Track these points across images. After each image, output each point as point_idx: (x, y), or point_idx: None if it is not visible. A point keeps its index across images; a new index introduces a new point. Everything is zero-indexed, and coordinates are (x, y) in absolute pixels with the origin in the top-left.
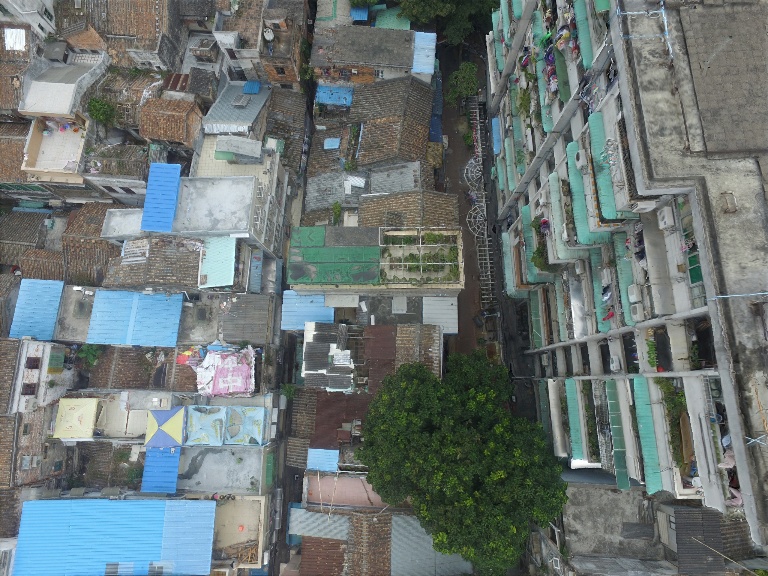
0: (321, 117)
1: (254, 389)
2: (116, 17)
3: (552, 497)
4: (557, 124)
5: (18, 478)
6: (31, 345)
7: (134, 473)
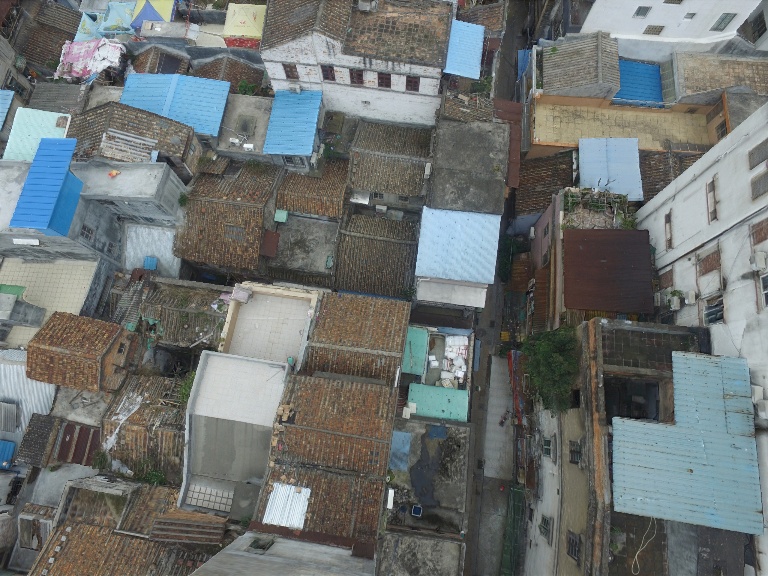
0: None
1: None
2: (132, 574)
3: None
4: None
5: None
6: None
7: None
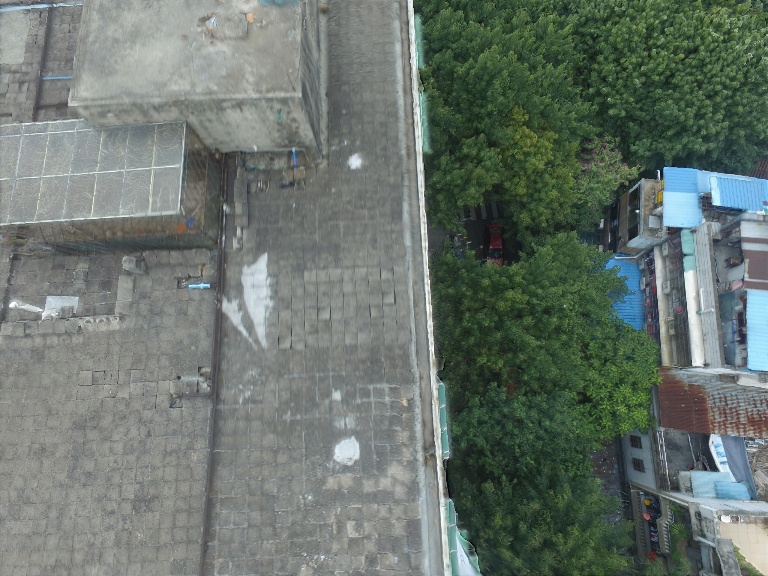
0: None
1: None
2: None
3: None
4: None
5: None
6: None
7: None
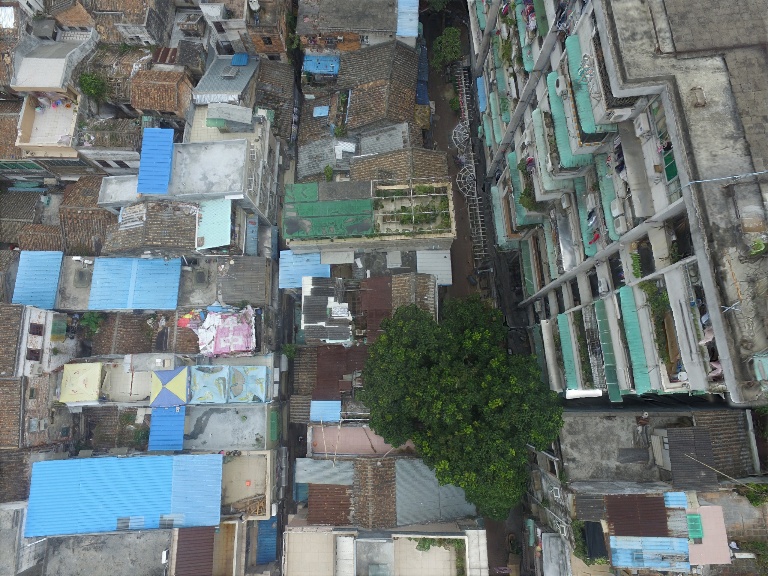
0: (309, 85)
1: (255, 349)
2: None
3: (548, 421)
4: (537, 61)
5: (27, 440)
6: (33, 311)
7: (141, 434)
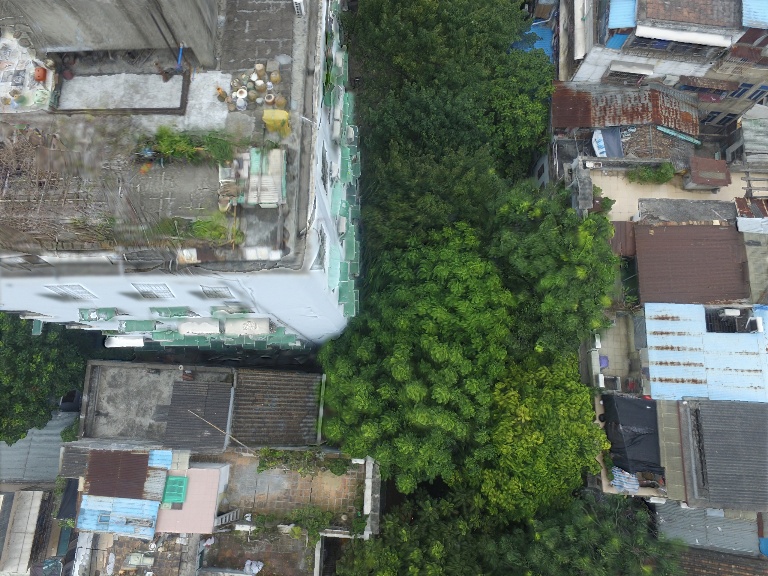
0: None
1: None
2: None
3: (29, 362)
4: None
5: None
6: None
7: None
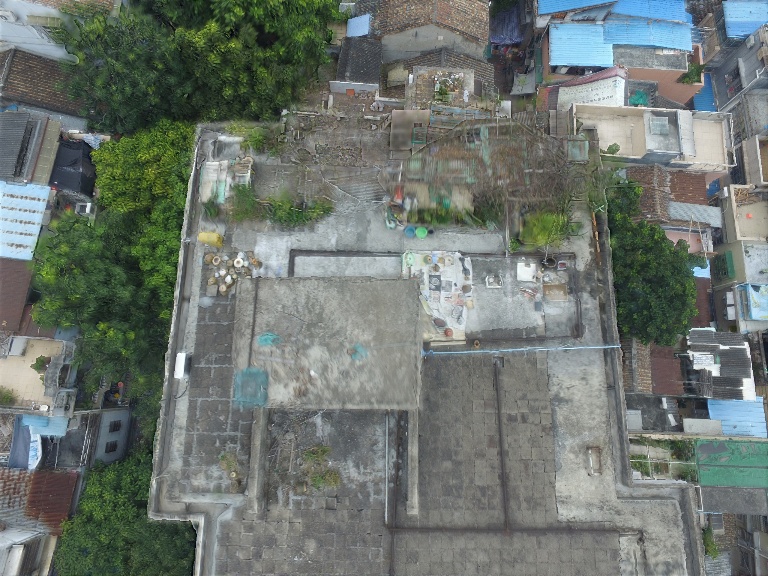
0: None
1: (764, 338)
2: None
3: None
4: None
5: None
6: None
7: None
